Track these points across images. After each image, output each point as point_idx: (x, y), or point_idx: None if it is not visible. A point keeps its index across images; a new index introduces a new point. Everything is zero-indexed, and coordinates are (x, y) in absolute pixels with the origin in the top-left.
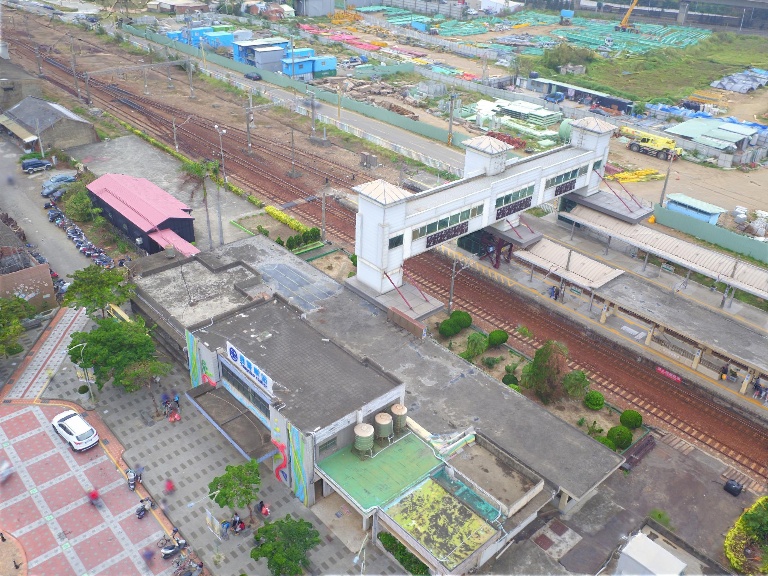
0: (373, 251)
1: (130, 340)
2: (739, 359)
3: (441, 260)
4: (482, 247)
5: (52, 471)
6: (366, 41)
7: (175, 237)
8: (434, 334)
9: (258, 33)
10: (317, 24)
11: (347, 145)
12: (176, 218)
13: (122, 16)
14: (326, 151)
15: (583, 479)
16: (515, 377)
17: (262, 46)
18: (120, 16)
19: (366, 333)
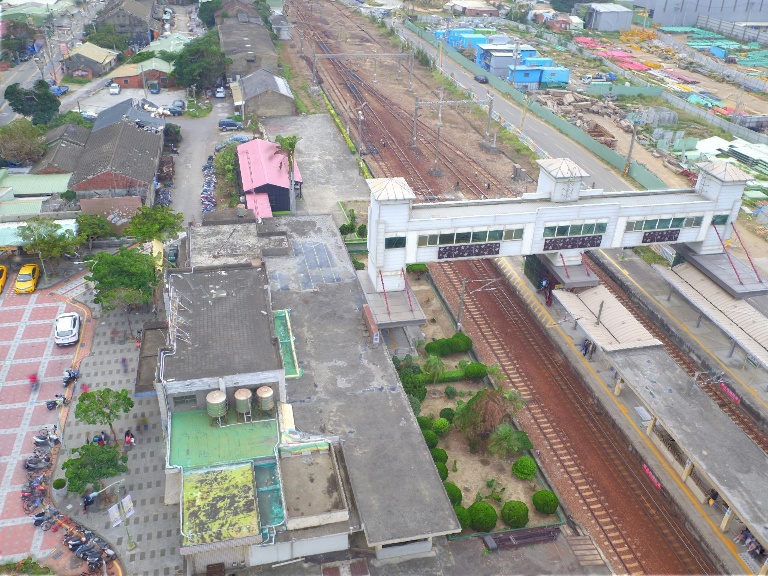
0: None
1: (128, 268)
2: (712, 482)
3: (504, 284)
4: (542, 279)
5: (31, 353)
6: (641, 61)
7: (265, 201)
8: None
9: (525, 40)
10: (601, 38)
11: (515, 156)
12: (274, 185)
13: (401, 12)
14: (489, 158)
15: (395, 528)
16: None
17: (502, 51)
18: (399, 12)
19: (333, 323)
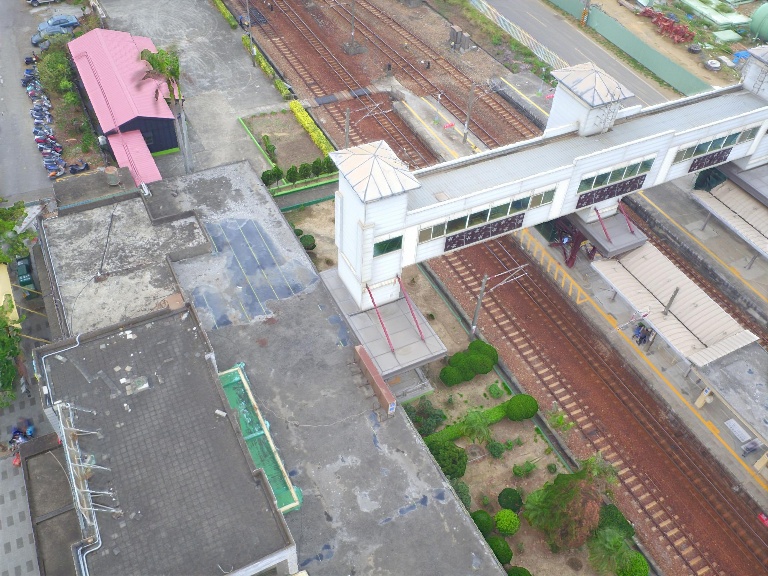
0: (353, 252)
1: None
2: None
3: None
4: (556, 230)
5: None
6: None
7: (140, 146)
8: (436, 371)
9: None
10: None
11: (442, 7)
12: (148, 117)
13: None
14: (411, 14)
15: None
16: (518, 498)
17: None
18: None
19: (315, 379)
